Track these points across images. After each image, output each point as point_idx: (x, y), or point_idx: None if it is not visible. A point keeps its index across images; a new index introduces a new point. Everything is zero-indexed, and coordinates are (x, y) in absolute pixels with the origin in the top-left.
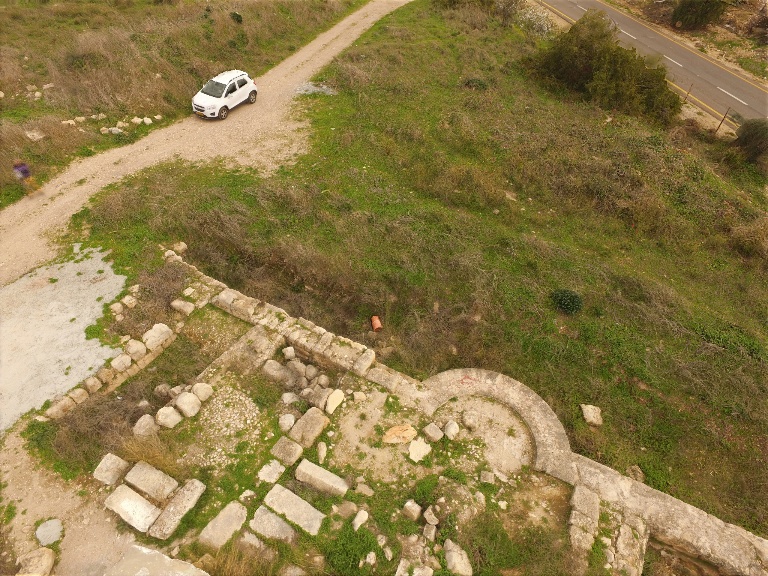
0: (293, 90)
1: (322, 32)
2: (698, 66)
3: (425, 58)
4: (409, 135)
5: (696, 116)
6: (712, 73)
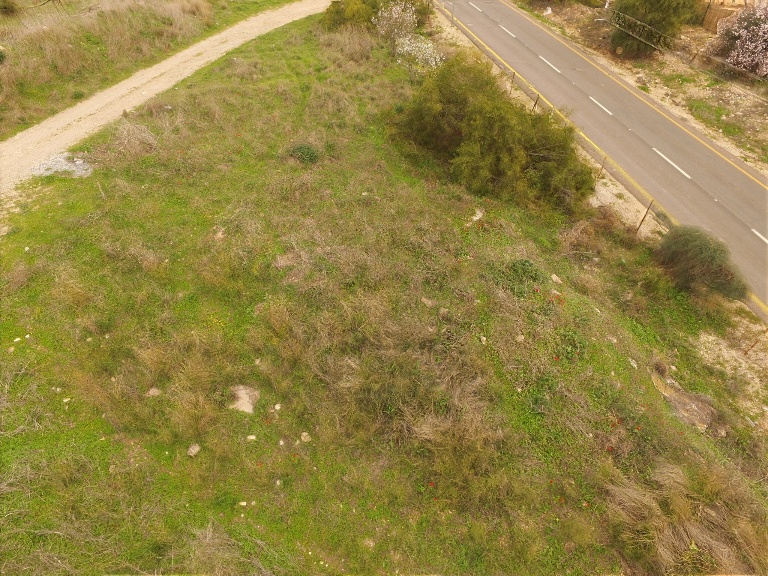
0: (29, 168)
1: (144, 67)
2: (633, 114)
3: (255, 109)
4: (138, 262)
5: (614, 200)
6: (649, 125)
